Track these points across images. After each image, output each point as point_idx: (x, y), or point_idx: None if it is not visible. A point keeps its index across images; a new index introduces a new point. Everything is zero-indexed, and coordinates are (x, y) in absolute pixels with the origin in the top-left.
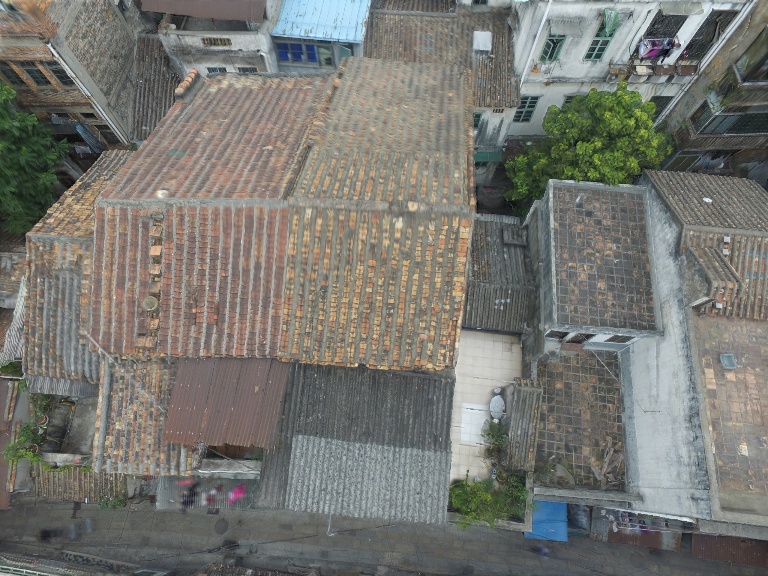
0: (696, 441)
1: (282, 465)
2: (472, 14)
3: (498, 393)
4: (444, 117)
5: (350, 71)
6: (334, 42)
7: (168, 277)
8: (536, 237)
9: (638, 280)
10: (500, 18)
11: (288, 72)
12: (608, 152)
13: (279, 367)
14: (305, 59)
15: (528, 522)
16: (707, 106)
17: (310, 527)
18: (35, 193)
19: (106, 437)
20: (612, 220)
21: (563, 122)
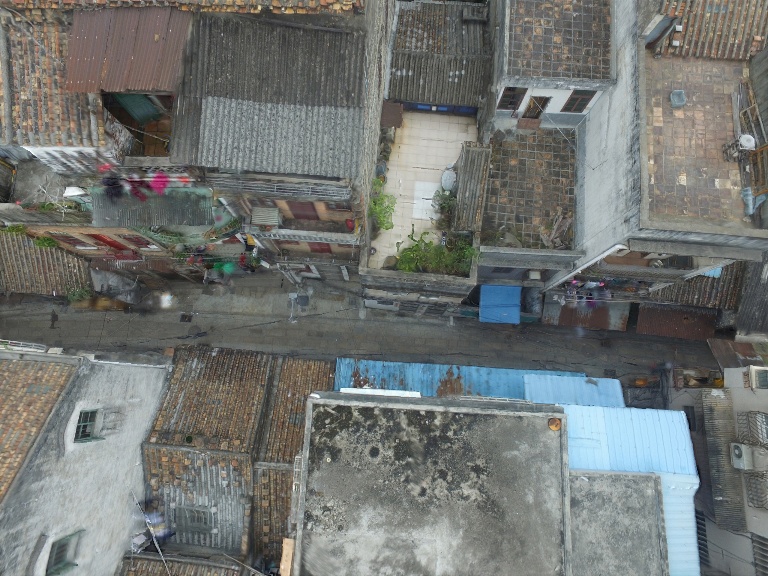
0: (634, 165)
1: (193, 125)
2: None
3: (450, 168)
4: None
5: None
6: None
7: None
8: (495, 4)
9: (597, 33)
10: None
11: None
12: None
13: (179, 16)
14: None
15: (473, 276)
16: None
17: (279, 330)
18: None
19: (12, 107)
20: None
21: None
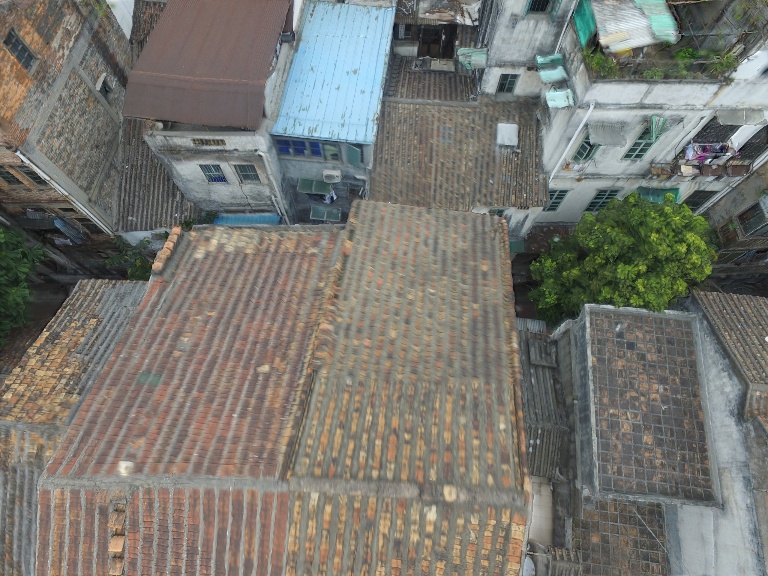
0: None
1: None
2: (496, 104)
3: None
4: (480, 312)
5: (363, 227)
6: (341, 142)
7: (133, 575)
8: (569, 365)
9: (690, 432)
10: (527, 108)
11: None
12: (654, 278)
13: None
14: (309, 154)
15: None
16: (760, 210)
17: None
18: (4, 309)
19: None
20: (658, 354)
21: (600, 235)
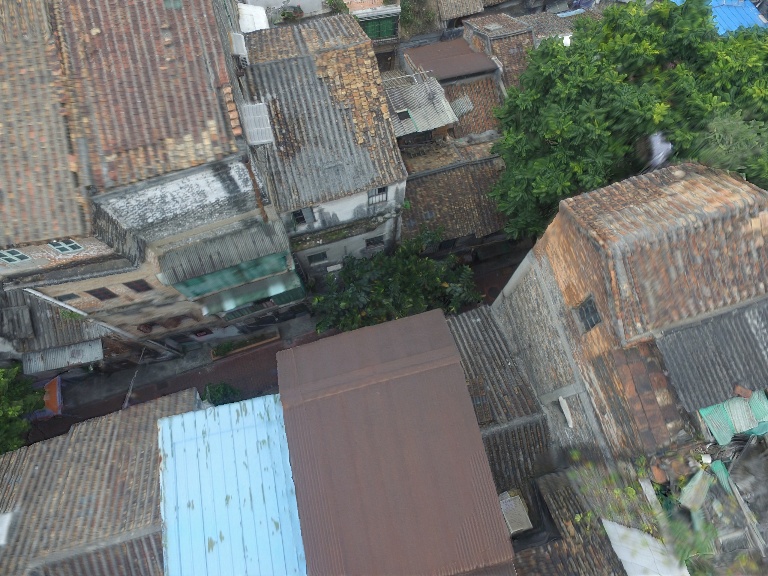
0: None
1: None
2: (1, 575)
3: None
4: None
5: (68, 195)
6: None
7: None
8: None
9: None
10: None
11: (146, 182)
12: None
13: None
14: None
15: None
16: None
17: None
18: None
19: None
20: None
21: None
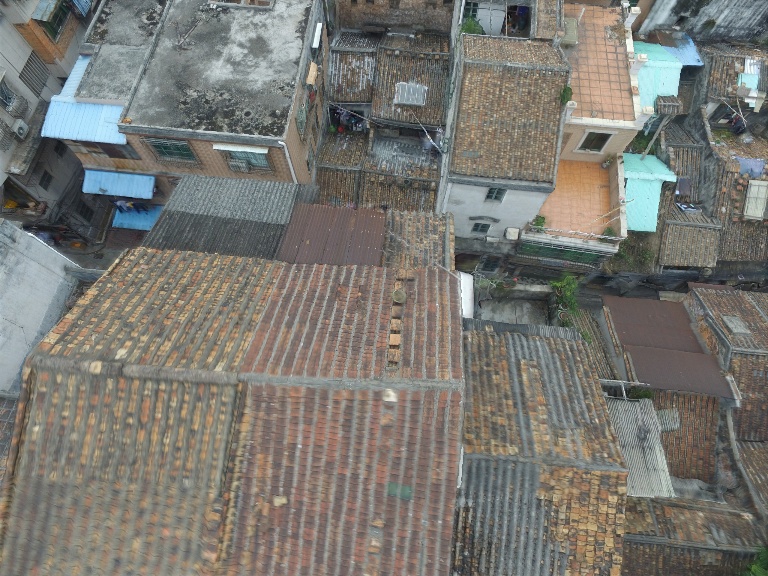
0: None
1: None
2: None
3: None
4: (26, 575)
5: None
6: None
7: (384, 320)
8: None
9: None
10: None
11: None
12: None
13: (288, 258)
14: None
15: None
16: None
17: None
18: None
19: None
20: None
21: None
